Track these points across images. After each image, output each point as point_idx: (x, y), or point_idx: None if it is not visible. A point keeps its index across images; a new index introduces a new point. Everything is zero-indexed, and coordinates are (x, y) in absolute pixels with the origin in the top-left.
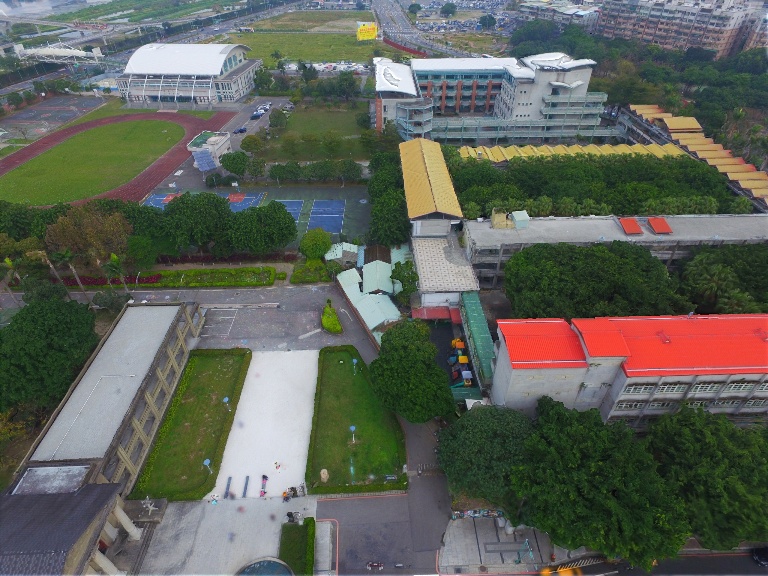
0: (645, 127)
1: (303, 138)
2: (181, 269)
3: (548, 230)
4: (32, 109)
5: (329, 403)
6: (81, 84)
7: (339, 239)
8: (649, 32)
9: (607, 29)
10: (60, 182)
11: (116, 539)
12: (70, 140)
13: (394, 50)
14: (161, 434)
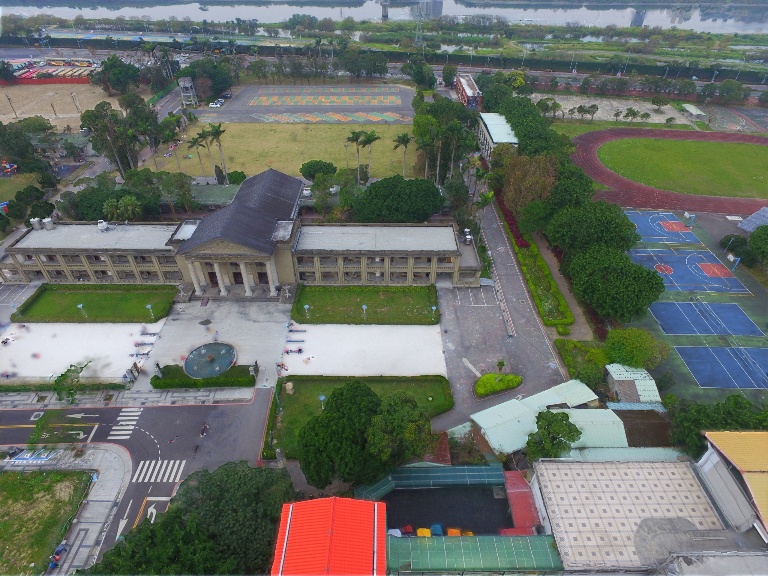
0: None
1: None
2: (545, 257)
3: None
4: None
5: (373, 390)
6: None
7: (683, 385)
8: None
9: None
10: (649, 162)
11: None
12: (733, 144)
13: None
14: (348, 287)
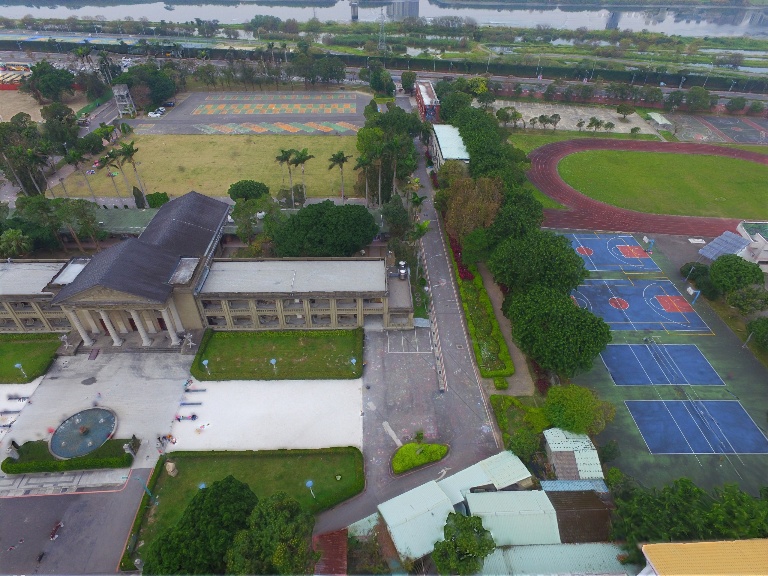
0: None
1: None
2: (490, 290)
3: None
4: (740, 119)
5: (272, 468)
6: None
7: (631, 452)
8: None
9: None
10: (611, 177)
11: (177, 333)
12: (699, 156)
13: None
14: (264, 332)
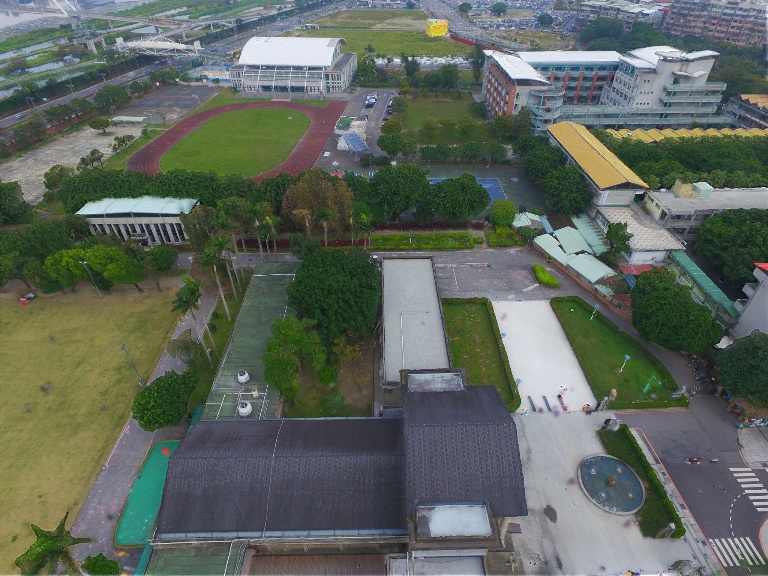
0: (761, 115)
1: (442, 123)
2: (383, 234)
3: (729, 199)
4: (151, 97)
5: (581, 341)
6: (190, 75)
7: None
8: (721, 30)
9: (676, 27)
10: (221, 161)
11: None
12: (205, 125)
13: (466, 46)
14: None
